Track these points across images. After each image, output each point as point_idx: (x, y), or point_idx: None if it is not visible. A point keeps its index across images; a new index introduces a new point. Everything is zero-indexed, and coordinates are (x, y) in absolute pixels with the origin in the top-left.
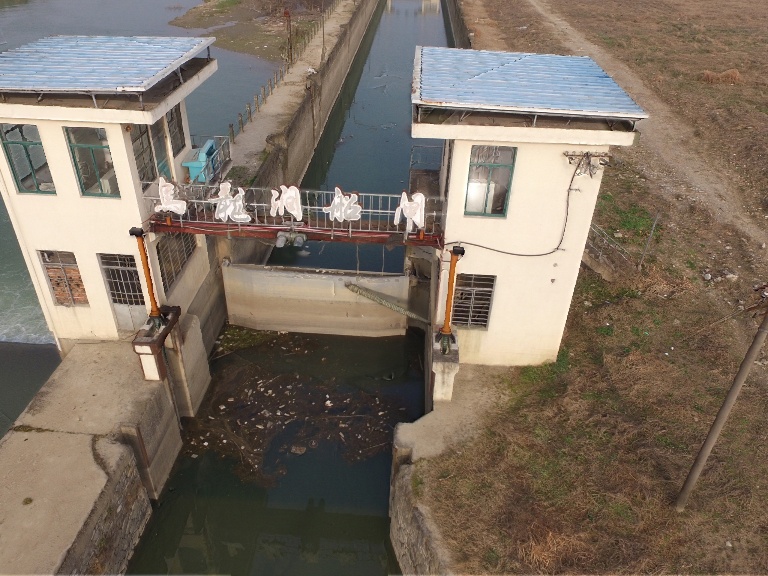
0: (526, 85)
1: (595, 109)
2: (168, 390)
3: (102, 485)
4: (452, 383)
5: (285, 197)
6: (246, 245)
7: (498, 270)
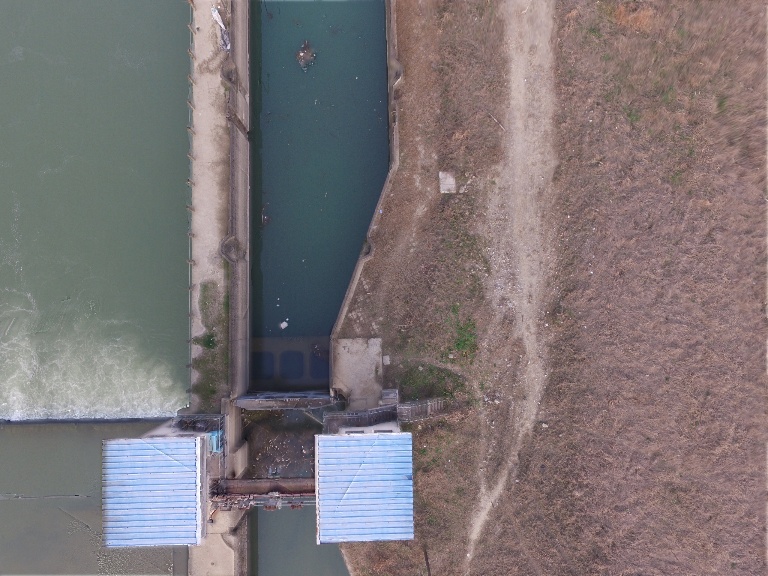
0: (367, 505)
1: (393, 535)
2: None
3: (233, 555)
4: None
5: None
6: (238, 366)
7: None
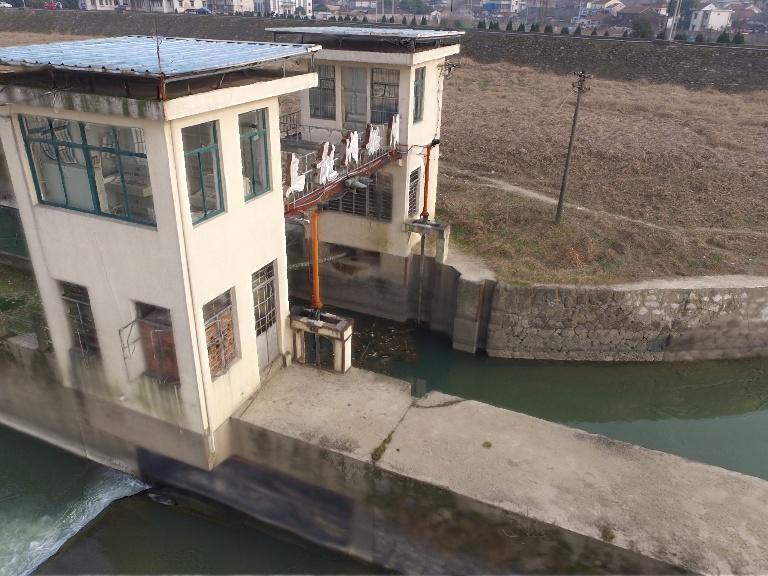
0: None
1: None
2: None
3: None
4: None
5: (352, 143)
6: None
7: None
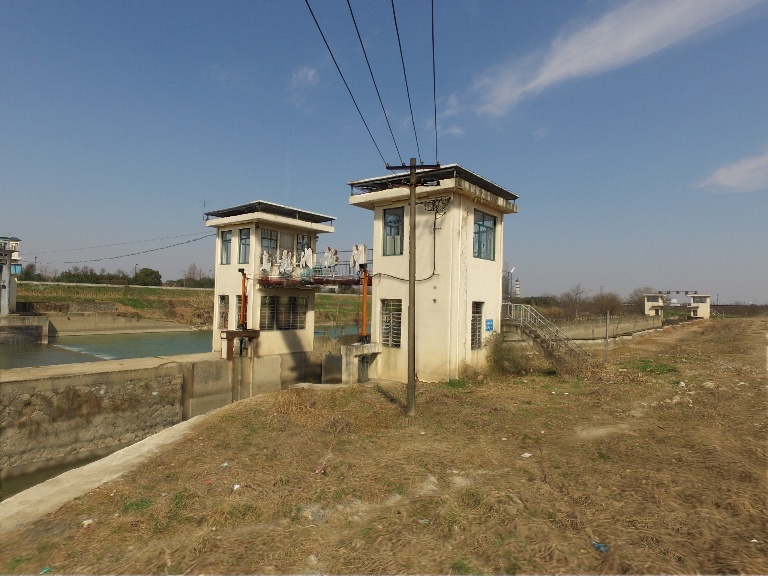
0: None
1: None
2: (231, 371)
3: (150, 367)
4: (351, 366)
5: (306, 255)
6: None
7: (402, 294)
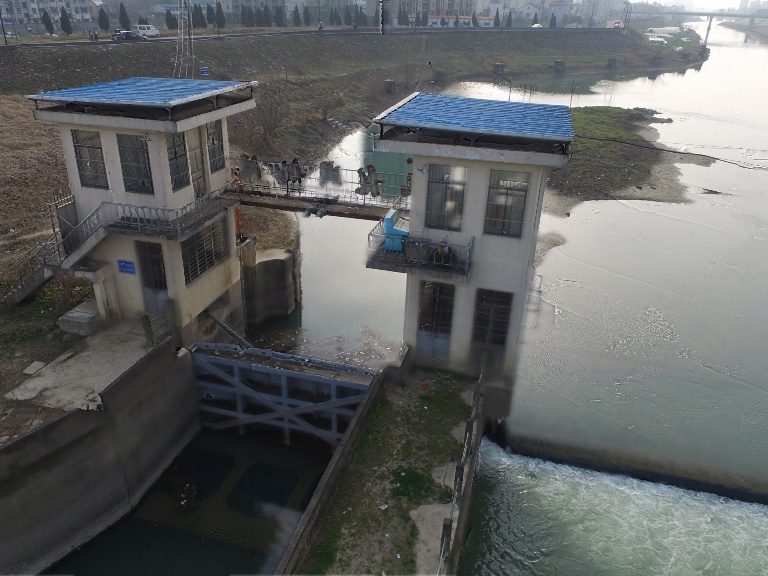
0: (163, 84)
1: None
2: None
3: None
4: None
5: None
6: None
7: None
